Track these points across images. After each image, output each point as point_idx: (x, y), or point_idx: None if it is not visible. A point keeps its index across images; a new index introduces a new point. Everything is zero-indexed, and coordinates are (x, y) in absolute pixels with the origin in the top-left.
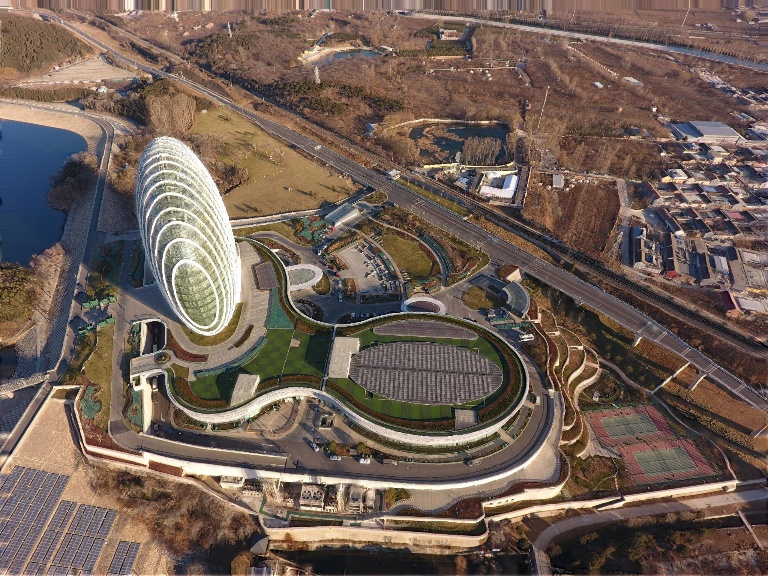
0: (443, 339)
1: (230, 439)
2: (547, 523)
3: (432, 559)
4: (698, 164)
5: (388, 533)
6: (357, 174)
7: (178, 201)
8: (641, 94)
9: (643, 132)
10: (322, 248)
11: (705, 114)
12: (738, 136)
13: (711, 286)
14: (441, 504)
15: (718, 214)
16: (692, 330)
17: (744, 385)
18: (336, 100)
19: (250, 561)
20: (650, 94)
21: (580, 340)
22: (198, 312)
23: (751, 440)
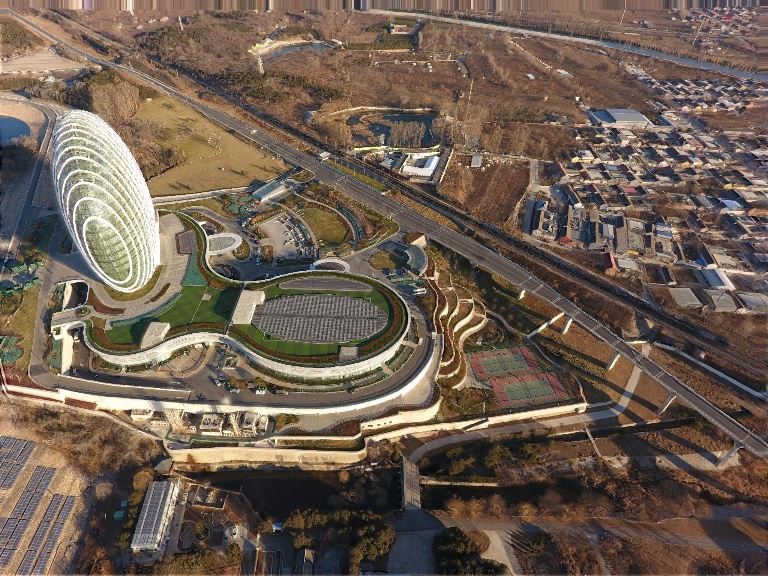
0: (341, 291)
1: (142, 379)
2: (421, 442)
3: (319, 474)
4: (607, 146)
5: (278, 452)
6: (289, 156)
7: (86, 164)
8: (568, 85)
9: (562, 118)
10: (247, 220)
11: (623, 103)
12: (647, 122)
13: (597, 249)
14: (325, 426)
15: (615, 189)
16: (570, 284)
17: (600, 325)
18: (279, 89)
19: (155, 479)
20: None
21: (472, 295)
22: (111, 266)
23: (606, 372)
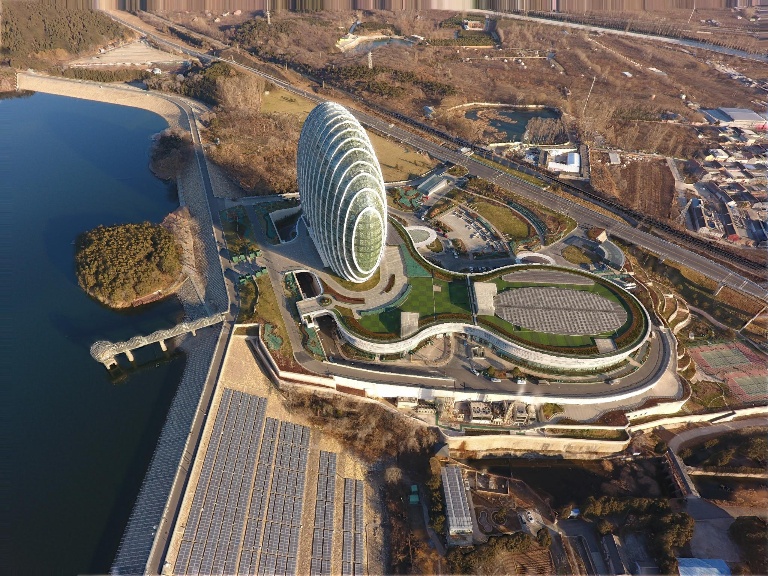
0: (565, 285)
1: (398, 367)
2: (673, 433)
3: (582, 463)
4: (734, 145)
5: (548, 440)
6: (433, 150)
7: (364, 156)
8: (668, 83)
9: (680, 116)
10: (424, 213)
11: (730, 102)
12: (765, 121)
13: None
14: (591, 416)
15: (762, 188)
16: (763, 281)
17: None
18: (390, 84)
19: None
20: (675, 83)
21: (669, 290)
22: (368, 256)
23: None
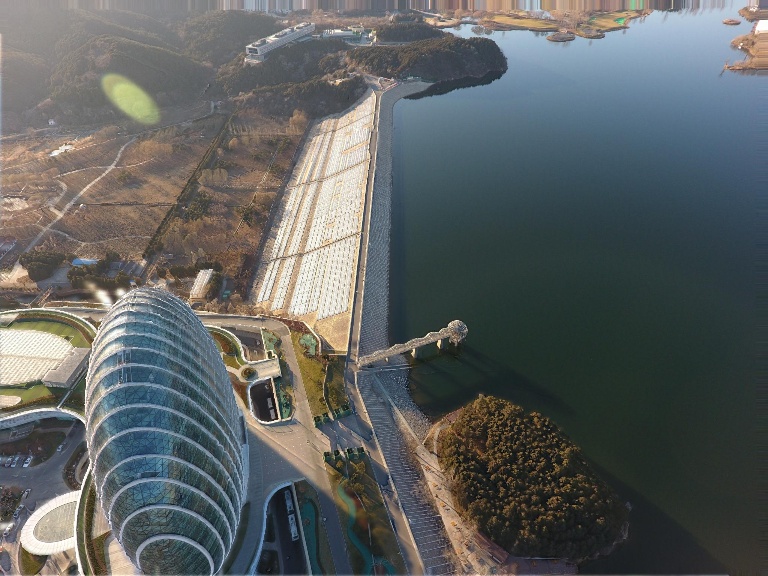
0: None
1: None
2: None
3: None
4: None
5: None
6: None
7: None
8: None
9: None
10: None
11: None
12: None
13: None
14: None
15: None
16: None
17: None
18: None
19: None
20: None
21: None
22: None
23: None
